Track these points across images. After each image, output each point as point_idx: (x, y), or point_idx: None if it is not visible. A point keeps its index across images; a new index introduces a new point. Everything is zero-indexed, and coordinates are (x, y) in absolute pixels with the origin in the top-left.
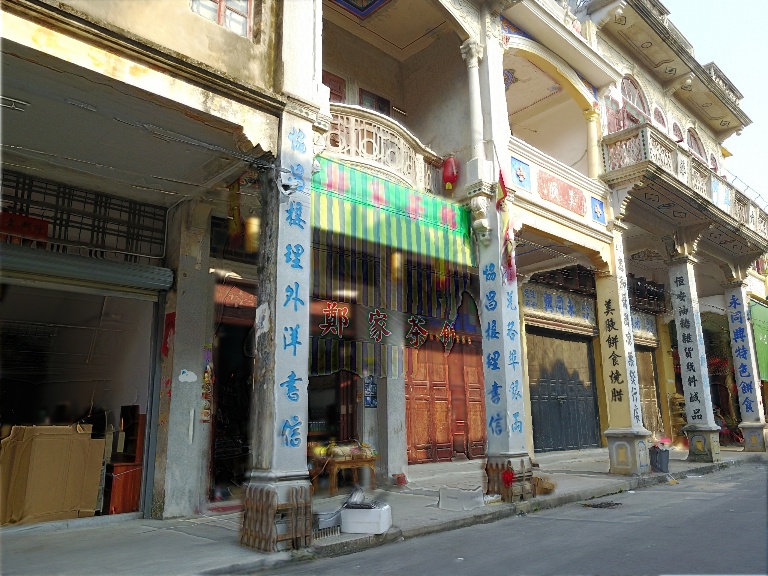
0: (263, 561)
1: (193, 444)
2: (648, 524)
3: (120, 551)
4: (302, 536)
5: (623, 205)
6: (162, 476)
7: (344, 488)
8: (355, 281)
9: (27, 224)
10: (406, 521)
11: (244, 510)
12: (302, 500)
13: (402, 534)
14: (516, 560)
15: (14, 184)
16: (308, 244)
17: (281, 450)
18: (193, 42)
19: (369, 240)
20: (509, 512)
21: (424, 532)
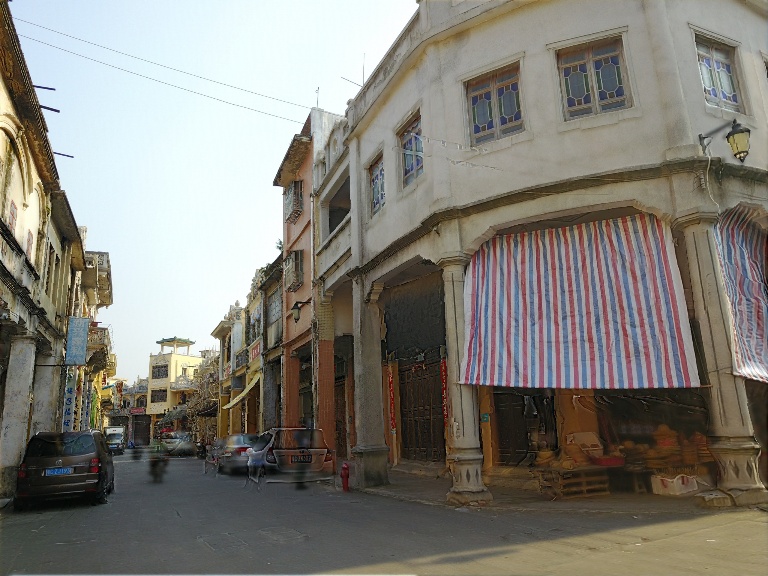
0: None
1: None
2: None
3: None
4: None
5: (89, 357)
6: None
7: None
8: None
9: None
10: None
11: None
12: None
13: None
14: None
15: None
16: None
17: None
18: None
19: None
20: None
21: None
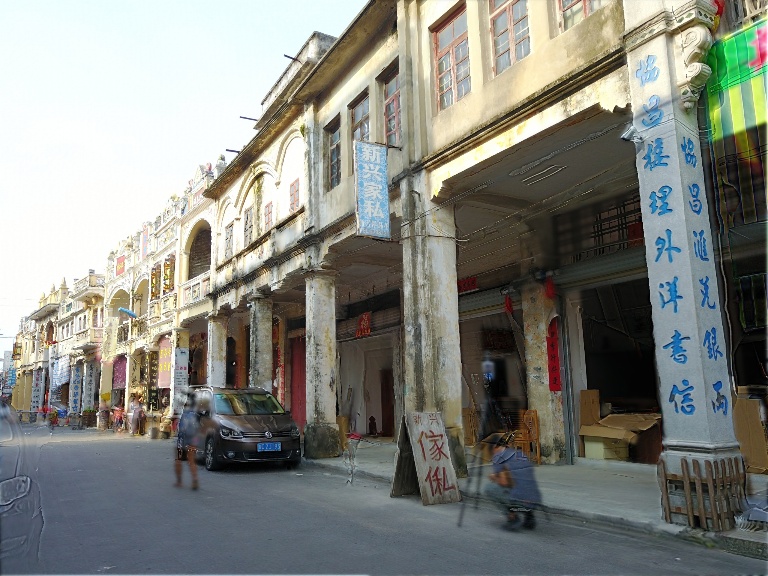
0: (646, 525)
1: None
2: None
3: (634, 492)
4: (701, 516)
5: None
6: None
7: None
8: None
9: None
10: None
11: None
12: (696, 475)
13: None
14: None
15: None
16: (676, 179)
17: (671, 417)
18: (556, 65)
19: None
20: None
21: None
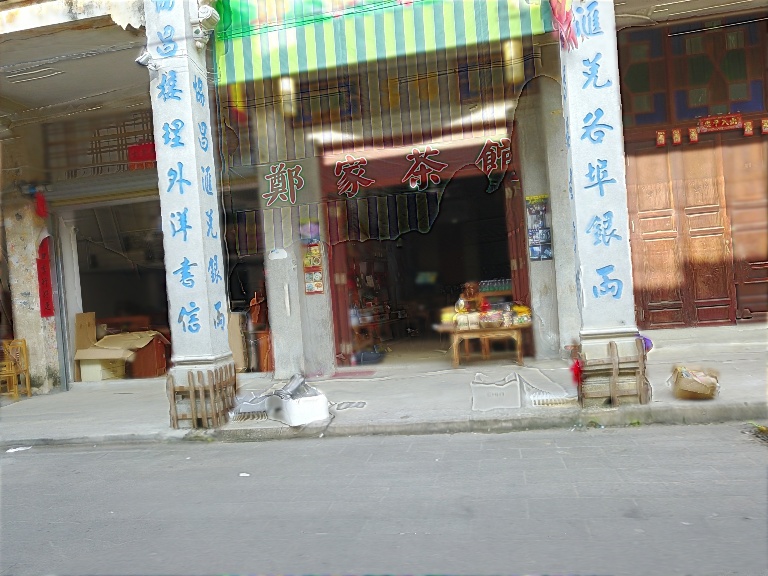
0: (156, 435)
1: (292, 316)
2: (630, 495)
3: None
4: (203, 418)
5: None
6: (273, 344)
7: (467, 361)
8: (310, 128)
9: (153, 150)
10: (372, 415)
11: (337, 378)
12: (200, 384)
13: (326, 430)
14: (241, 494)
15: (141, 120)
16: (188, 115)
17: (179, 336)
18: None
19: (329, 67)
20: (557, 421)
21: (367, 431)
